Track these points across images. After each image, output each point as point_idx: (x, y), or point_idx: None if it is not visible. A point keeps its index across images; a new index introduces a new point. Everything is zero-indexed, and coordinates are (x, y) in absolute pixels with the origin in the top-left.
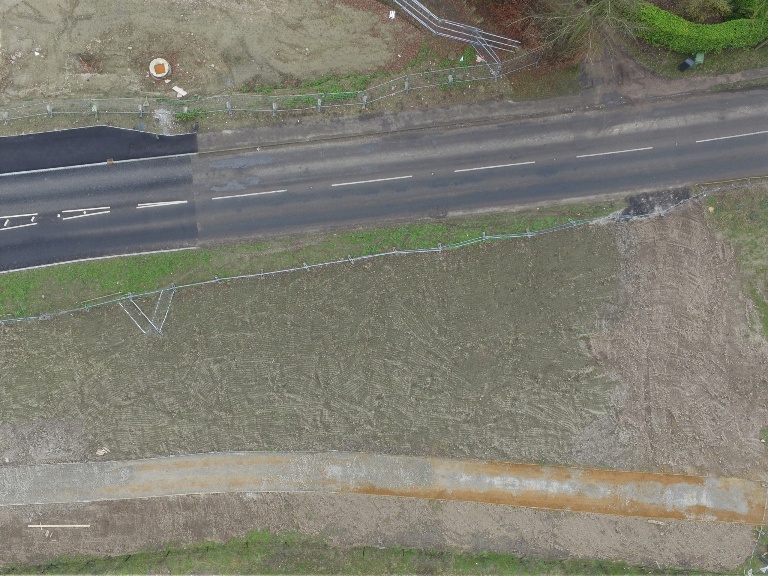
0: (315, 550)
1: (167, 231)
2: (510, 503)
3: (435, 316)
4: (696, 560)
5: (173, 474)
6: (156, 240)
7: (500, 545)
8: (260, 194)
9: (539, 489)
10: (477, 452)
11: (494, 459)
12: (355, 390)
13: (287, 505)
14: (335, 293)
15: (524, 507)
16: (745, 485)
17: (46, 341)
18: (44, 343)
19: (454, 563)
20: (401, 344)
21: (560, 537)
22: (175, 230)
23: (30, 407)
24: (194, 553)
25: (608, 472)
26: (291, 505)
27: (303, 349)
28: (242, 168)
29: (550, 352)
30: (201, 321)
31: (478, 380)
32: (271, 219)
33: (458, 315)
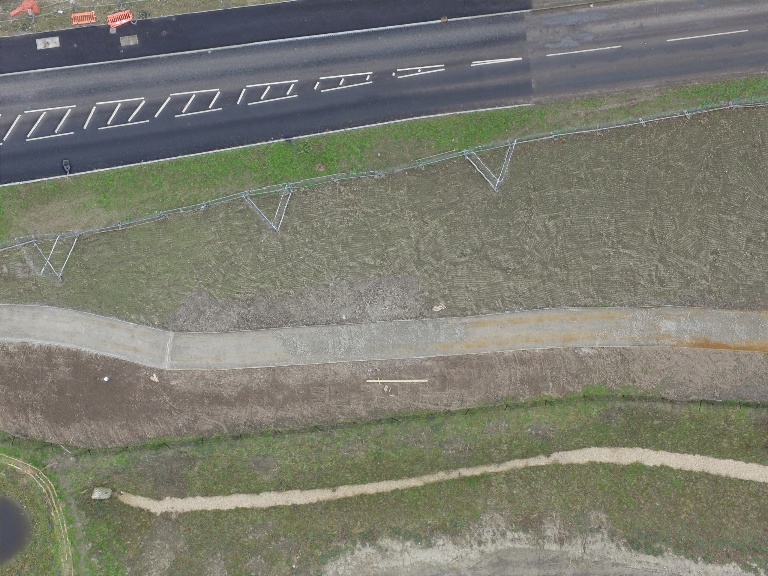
0: (651, 403)
1: (502, 88)
2: None
3: None
4: None
5: (507, 330)
6: (491, 97)
7: None
8: (594, 50)
9: None
10: None
11: None
12: (690, 245)
13: (623, 359)
14: (671, 148)
15: None
16: None
17: (381, 199)
18: (379, 201)
19: None
20: (736, 199)
21: None
22: (510, 87)
23: (366, 264)
24: (532, 407)
25: None
26: (627, 359)
27: (638, 205)
28: (576, 25)
29: None
30: (536, 178)
31: None
32: (606, 75)
33: None
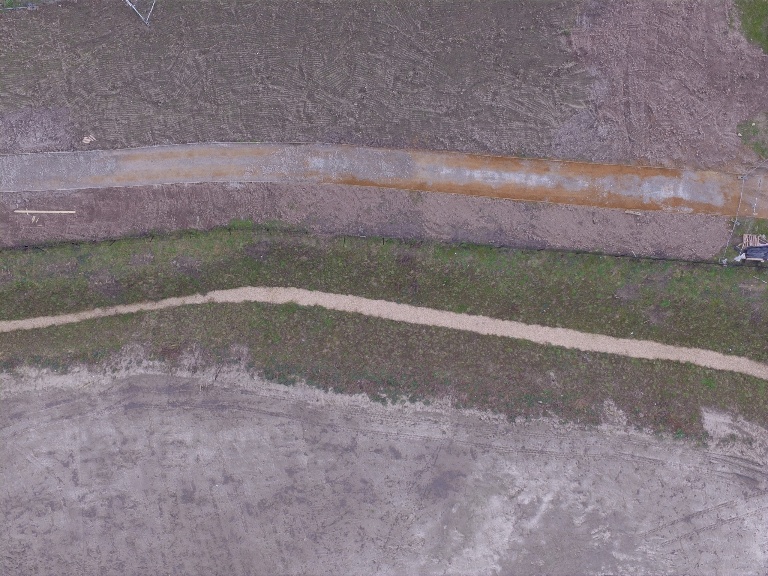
0: (297, 238)
1: None
2: (489, 195)
3: (418, 10)
4: (672, 250)
5: (158, 164)
6: None
7: (479, 236)
8: None
9: (518, 182)
10: (458, 145)
11: (474, 152)
12: (338, 82)
13: (270, 194)
14: None
15: (503, 199)
16: (721, 178)
17: (34, 31)
18: (32, 33)
19: (433, 253)
20: (384, 38)
21: (538, 228)
22: None
23: (18, 96)
24: (177, 239)
25: (586, 165)
26: (274, 194)
27: (287, 41)
28: None
29: (531, 48)
30: (187, 13)
31: (460, 75)
32: None
33: (441, 9)
